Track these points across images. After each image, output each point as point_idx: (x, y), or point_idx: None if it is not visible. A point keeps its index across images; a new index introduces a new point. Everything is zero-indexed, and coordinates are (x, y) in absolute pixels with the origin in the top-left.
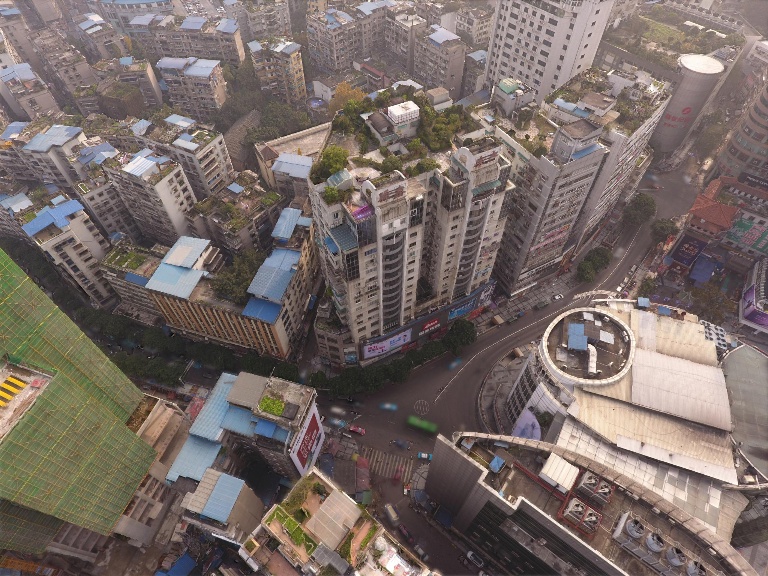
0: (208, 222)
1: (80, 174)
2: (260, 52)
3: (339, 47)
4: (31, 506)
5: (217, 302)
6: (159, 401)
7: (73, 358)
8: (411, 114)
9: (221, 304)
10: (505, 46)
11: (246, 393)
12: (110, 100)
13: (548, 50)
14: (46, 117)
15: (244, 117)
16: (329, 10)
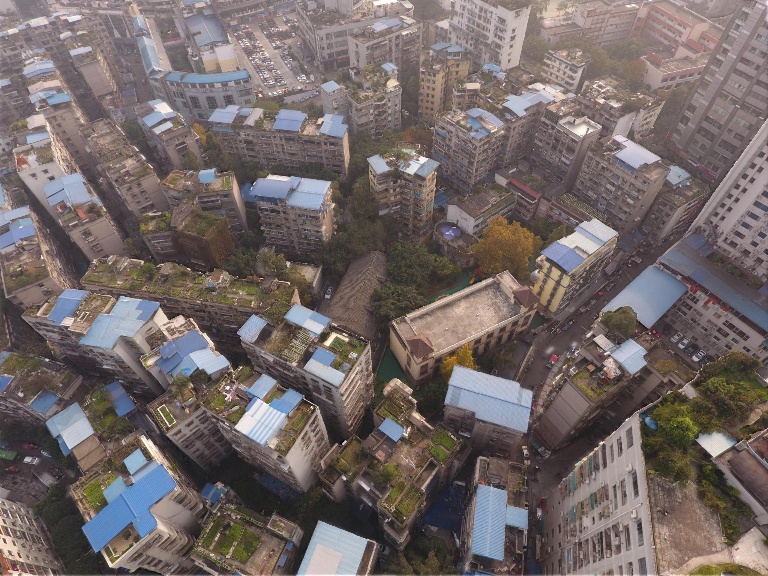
0: (352, 484)
1: (157, 377)
2: (385, 172)
3: (481, 158)
4: None
5: None
6: None
7: None
8: None
9: None
10: (763, 195)
11: None
12: (188, 237)
13: None
14: (106, 265)
15: (363, 261)
16: (471, 111)
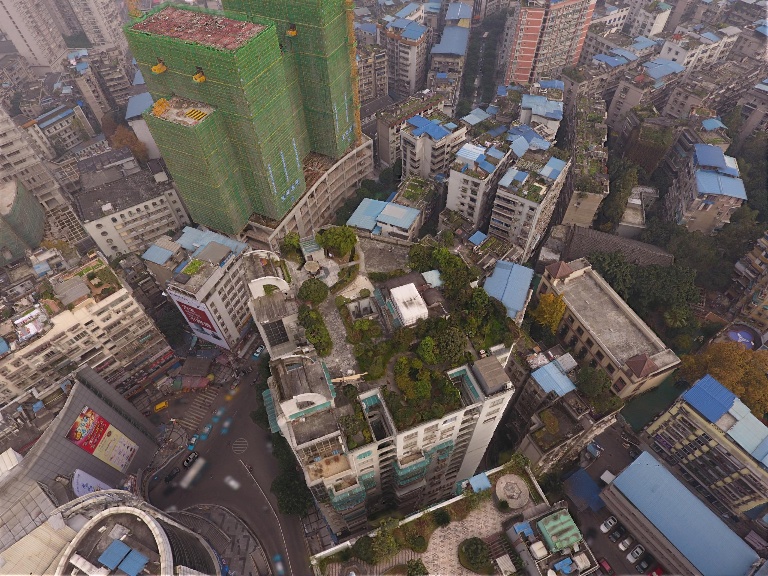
0: None
1: None
2: None
3: None
4: (163, 157)
5: None
6: (274, 230)
7: (248, 150)
8: None
9: None
10: None
11: (211, 252)
12: None
13: None
14: None
15: (658, 249)
16: None
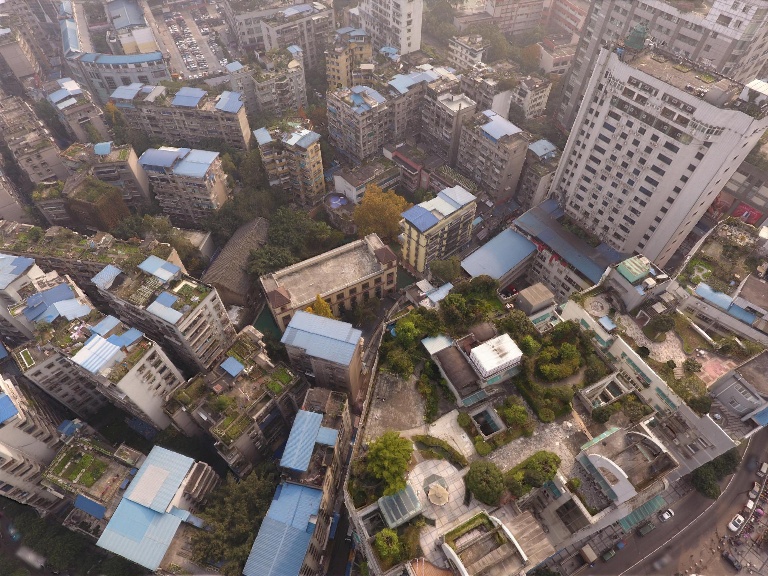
0: (193, 416)
1: (27, 326)
2: (269, 143)
3: (367, 132)
4: None
5: (200, 570)
6: None
7: None
8: (509, 362)
9: (205, 574)
10: (590, 159)
11: None
12: (79, 204)
13: (658, 179)
14: None
15: (247, 226)
16: (355, 88)
